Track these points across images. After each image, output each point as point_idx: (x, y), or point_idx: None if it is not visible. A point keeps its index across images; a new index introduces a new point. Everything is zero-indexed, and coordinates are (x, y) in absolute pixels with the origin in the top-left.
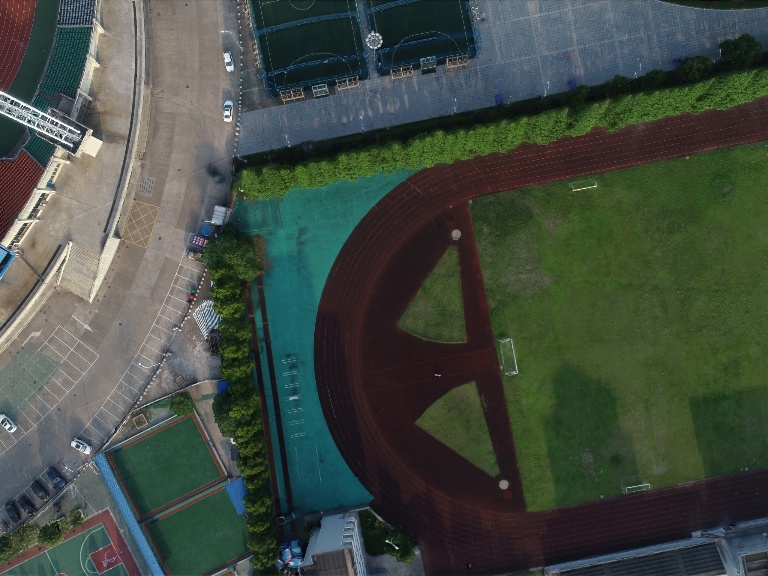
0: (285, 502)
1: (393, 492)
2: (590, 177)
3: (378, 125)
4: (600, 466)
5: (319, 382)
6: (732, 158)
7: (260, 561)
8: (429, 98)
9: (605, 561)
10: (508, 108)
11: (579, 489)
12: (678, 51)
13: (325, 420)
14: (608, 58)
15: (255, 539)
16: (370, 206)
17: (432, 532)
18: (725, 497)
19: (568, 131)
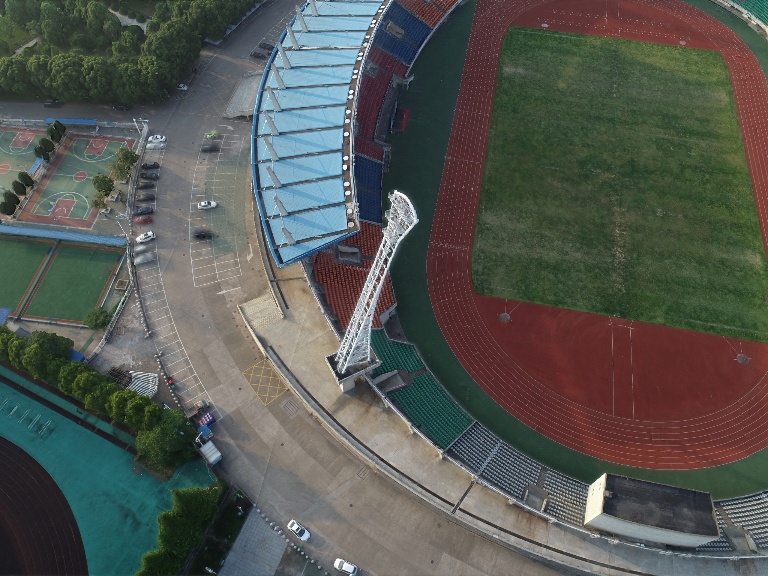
0: None
1: None
2: None
3: None
4: None
5: (4, 443)
6: None
7: None
8: None
9: None
10: None
11: None
12: None
13: None
14: None
15: None
16: None
17: None
18: None
19: None
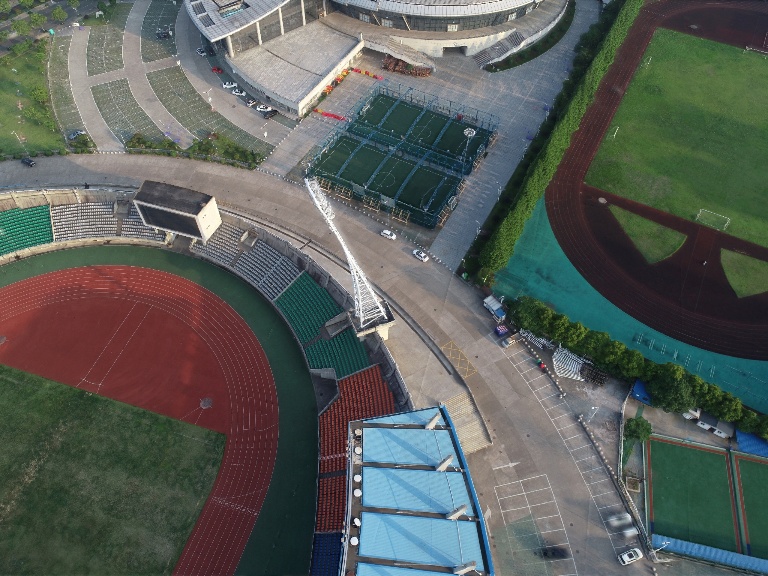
0: None
1: None
2: (609, 130)
3: None
4: None
5: (669, 334)
6: (639, 80)
7: None
8: (502, 163)
9: None
10: (538, 137)
11: None
12: (562, 68)
13: (706, 350)
14: (543, 91)
15: None
16: (549, 228)
17: None
18: None
19: None
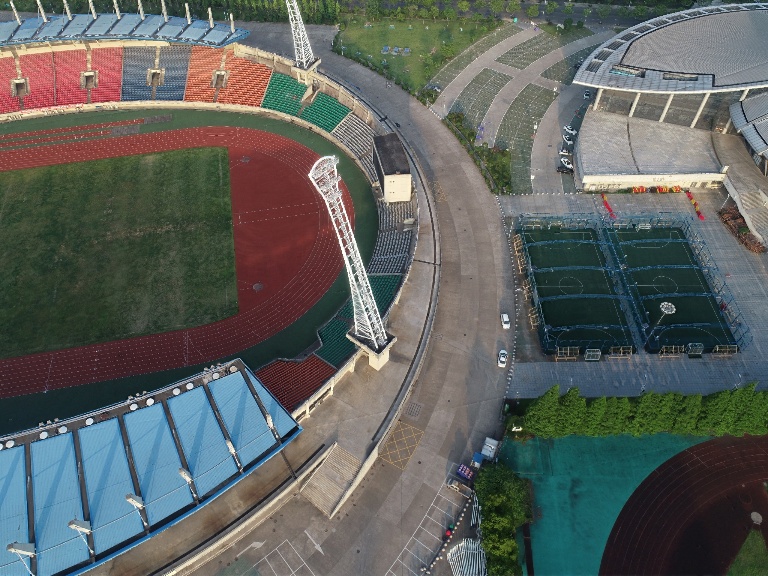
0: None
1: None
2: None
3: None
4: None
5: None
6: None
7: None
8: (699, 378)
9: None
10: None
11: None
12: None
13: None
14: None
15: None
16: (650, 469)
17: None
18: None
19: None
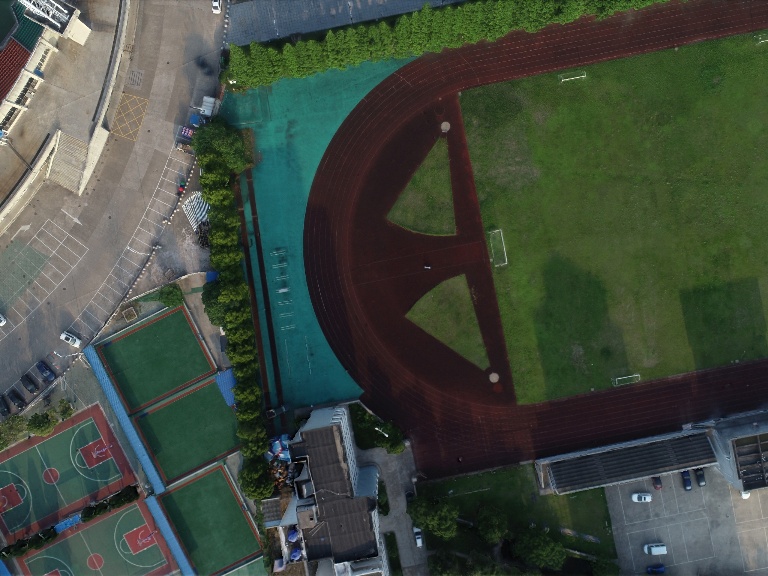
0: (275, 396)
1: (383, 386)
2: (579, 69)
3: (367, 17)
4: (590, 359)
5: (309, 275)
6: (721, 49)
7: (250, 449)
8: None
9: (595, 452)
10: None
11: (569, 382)
12: None
13: (315, 313)
14: None
15: (245, 427)
16: (359, 98)
17: (422, 426)
18: (716, 389)
19: (556, 17)
